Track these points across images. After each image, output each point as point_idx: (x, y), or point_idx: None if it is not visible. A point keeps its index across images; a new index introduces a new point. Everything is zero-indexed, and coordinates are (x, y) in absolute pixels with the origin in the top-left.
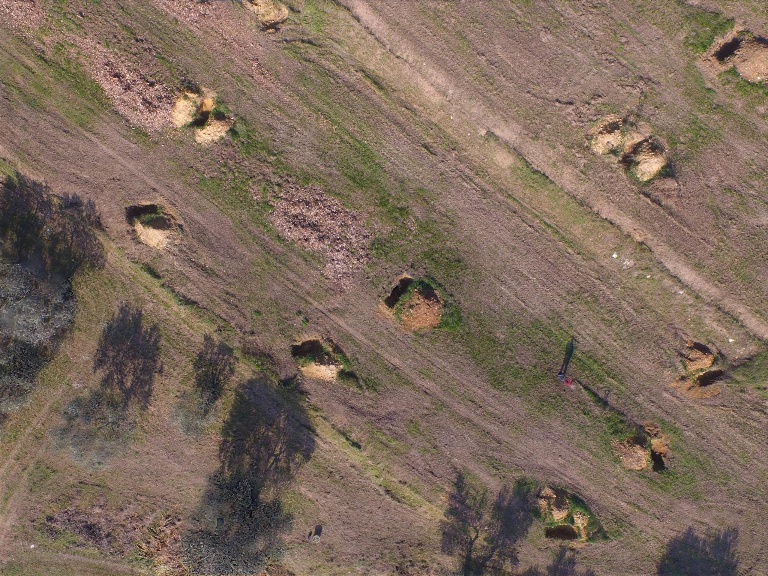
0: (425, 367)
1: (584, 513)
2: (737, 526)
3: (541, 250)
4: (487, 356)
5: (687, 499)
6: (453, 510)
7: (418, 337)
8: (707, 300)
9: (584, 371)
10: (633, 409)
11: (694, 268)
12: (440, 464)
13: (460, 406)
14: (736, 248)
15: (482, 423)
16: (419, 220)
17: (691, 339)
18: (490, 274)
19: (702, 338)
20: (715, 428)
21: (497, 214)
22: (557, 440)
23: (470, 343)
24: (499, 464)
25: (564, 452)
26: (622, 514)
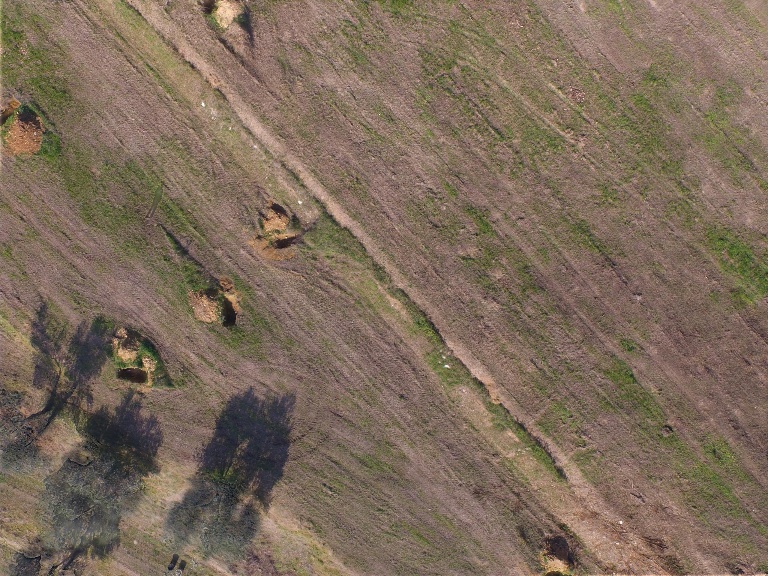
0: (23, 193)
1: (153, 358)
2: (295, 392)
3: (142, 92)
4: (81, 190)
5: (251, 358)
6: (35, 339)
7: (19, 162)
8: (275, 156)
9: (170, 218)
10: (211, 262)
11: (259, 120)
12: (27, 291)
13: (51, 236)
14: (300, 105)
15: (70, 256)
16: (31, 46)
17: (272, 200)
18: (92, 109)
19: (279, 199)
20: (285, 291)
21: (104, 50)
22: (138, 283)
23: (67, 175)
24: (81, 298)
25: (143, 295)
26: (190, 365)
